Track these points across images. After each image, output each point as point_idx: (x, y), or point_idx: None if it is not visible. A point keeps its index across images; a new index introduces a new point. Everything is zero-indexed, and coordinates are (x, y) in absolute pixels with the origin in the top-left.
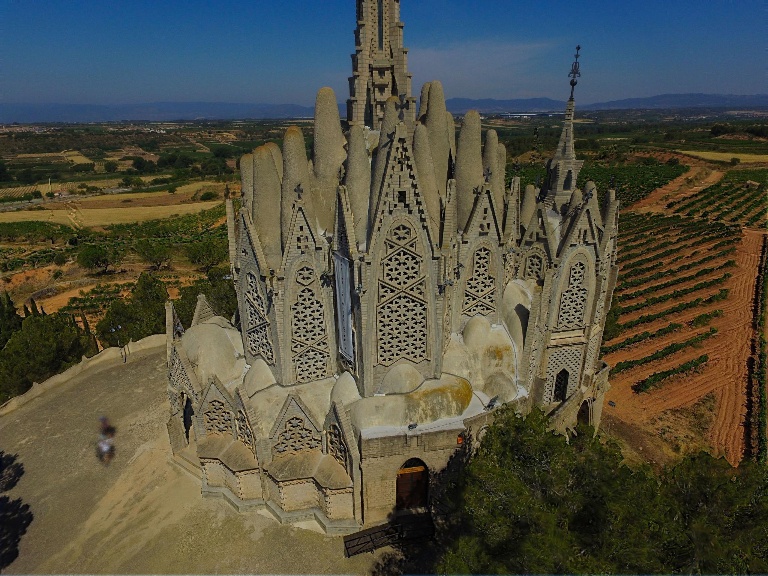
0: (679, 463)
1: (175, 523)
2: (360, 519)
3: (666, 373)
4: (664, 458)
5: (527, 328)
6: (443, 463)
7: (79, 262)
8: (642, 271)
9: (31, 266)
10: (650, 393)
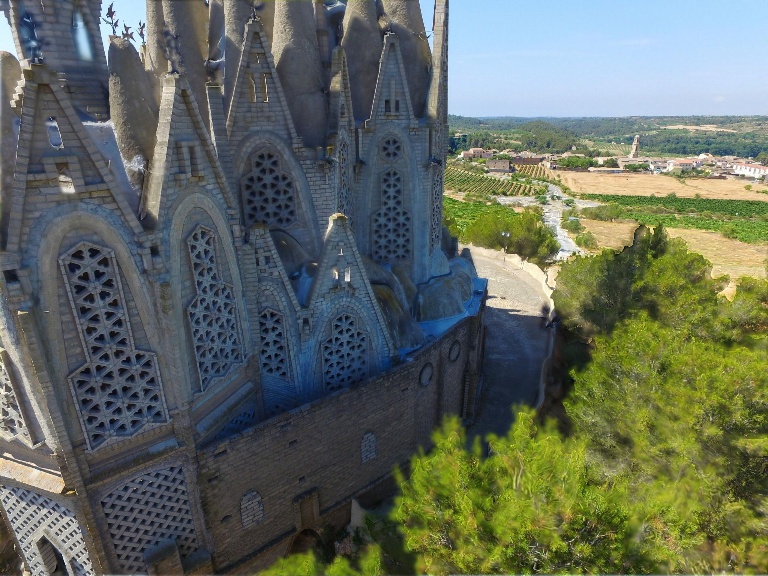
0: None
1: None
2: None
3: None
4: None
5: None
6: None
7: None
8: None
9: None
10: None
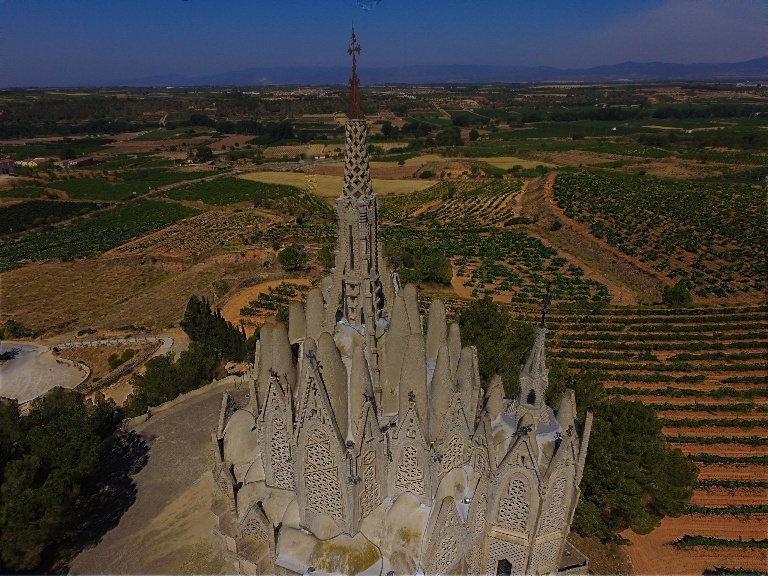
0: None
1: (190, 546)
2: None
3: None
4: None
5: None
6: None
7: (279, 258)
8: None
9: (260, 245)
10: None
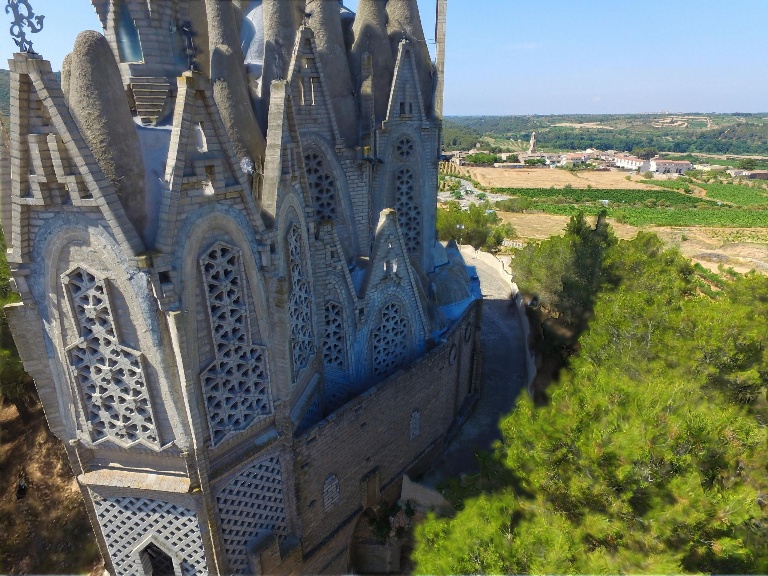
0: None
1: None
2: None
3: None
4: None
5: None
6: None
7: None
8: None
9: None
10: None
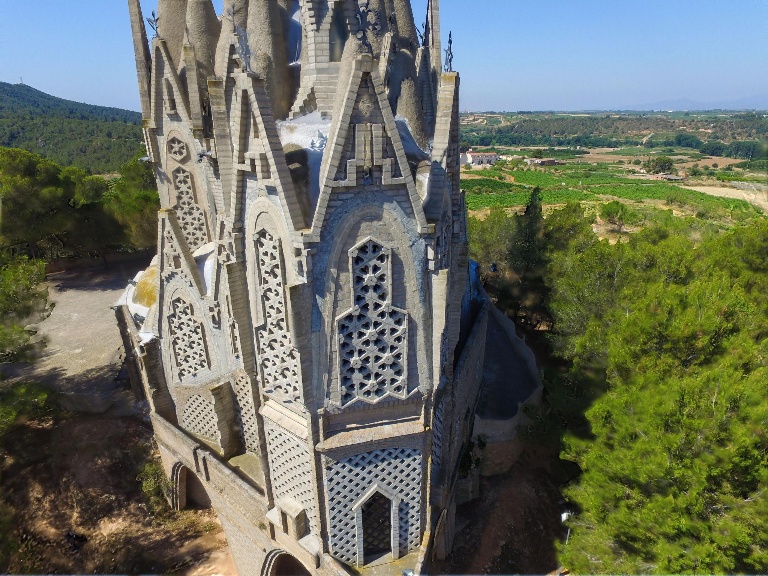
0: None
1: None
2: None
3: None
4: None
5: None
6: None
7: None
8: None
9: None
10: None
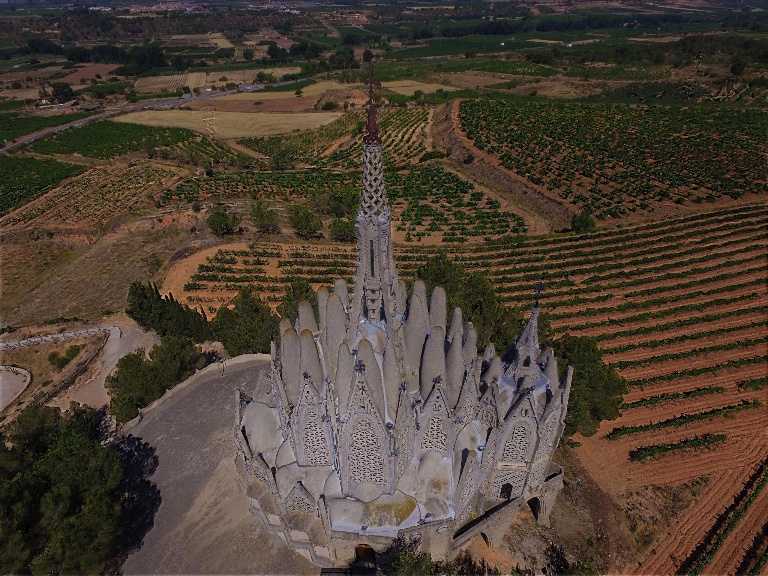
0: (588, 568)
1: (232, 528)
2: (333, 560)
3: (667, 449)
4: (617, 534)
5: (461, 475)
6: (384, 550)
7: (208, 224)
8: (726, 302)
9: (176, 208)
10: (644, 463)
